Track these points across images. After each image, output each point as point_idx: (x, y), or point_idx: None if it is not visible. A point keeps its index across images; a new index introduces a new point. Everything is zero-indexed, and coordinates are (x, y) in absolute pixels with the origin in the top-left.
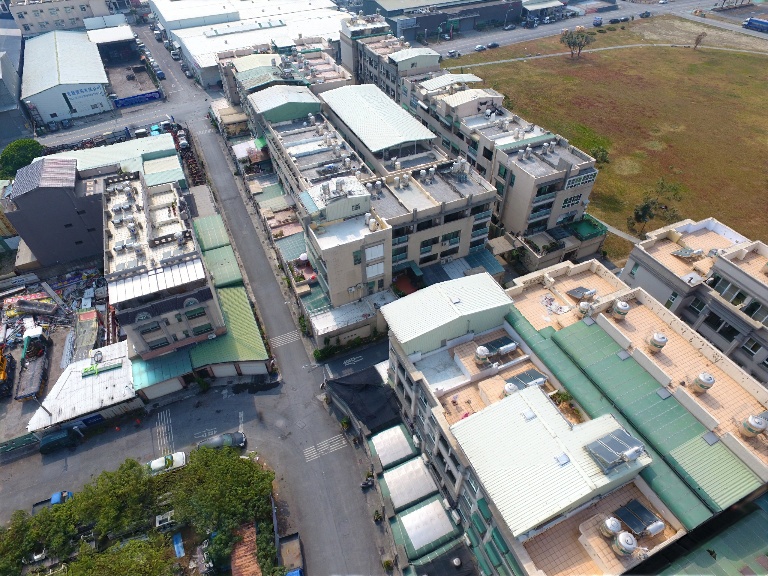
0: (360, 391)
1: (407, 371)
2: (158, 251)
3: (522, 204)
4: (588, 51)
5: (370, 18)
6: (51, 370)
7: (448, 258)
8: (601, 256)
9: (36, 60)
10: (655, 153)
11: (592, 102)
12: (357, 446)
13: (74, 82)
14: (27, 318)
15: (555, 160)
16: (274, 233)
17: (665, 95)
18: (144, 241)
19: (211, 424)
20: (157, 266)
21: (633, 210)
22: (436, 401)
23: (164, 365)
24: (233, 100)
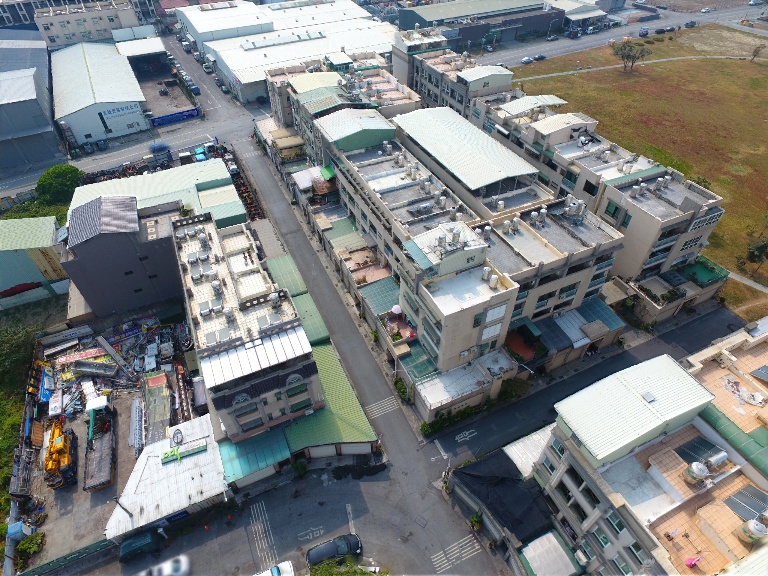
0: (495, 485)
1: (593, 487)
2: (251, 315)
3: (638, 248)
4: (640, 63)
5: (426, 32)
6: (119, 448)
7: (561, 311)
8: (718, 302)
9: (66, 75)
10: (742, 178)
11: (658, 120)
12: (494, 552)
13: (110, 100)
14: (85, 382)
15: (672, 197)
16: (354, 278)
17: (734, 112)
18: (231, 302)
19: (315, 521)
20: (254, 336)
21: (736, 246)
22: (654, 539)
23: (257, 449)
24: (285, 121)
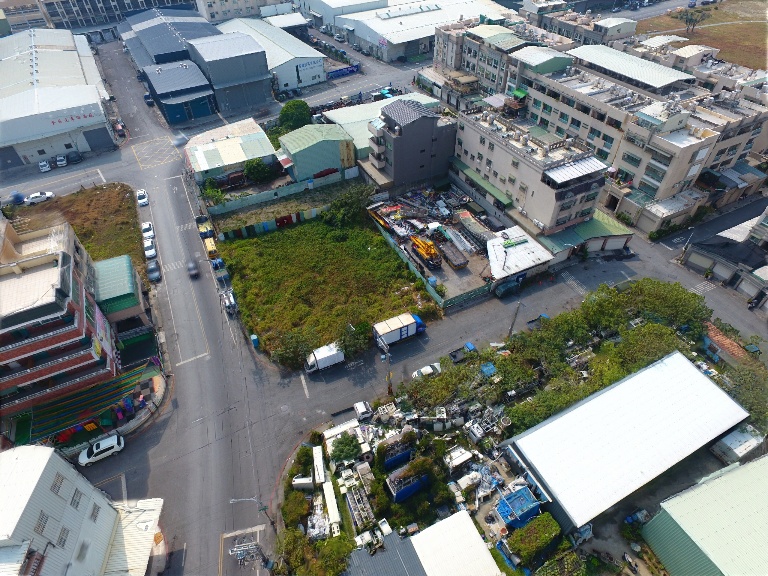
0: (722, 248)
1: None
2: (555, 153)
3: None
4: (697, 27)
5: None
6: None
7: (724, 167)
8: None
9: None
10: None
11: None
12: (725, 287)
13: (304, 56)
14: (410, 220)
15: None
16: None
17: None
18: None
19: (606, 278)
20: (569, 161)
21: None
22: None
23: (562, 238)
24: (455, 66)
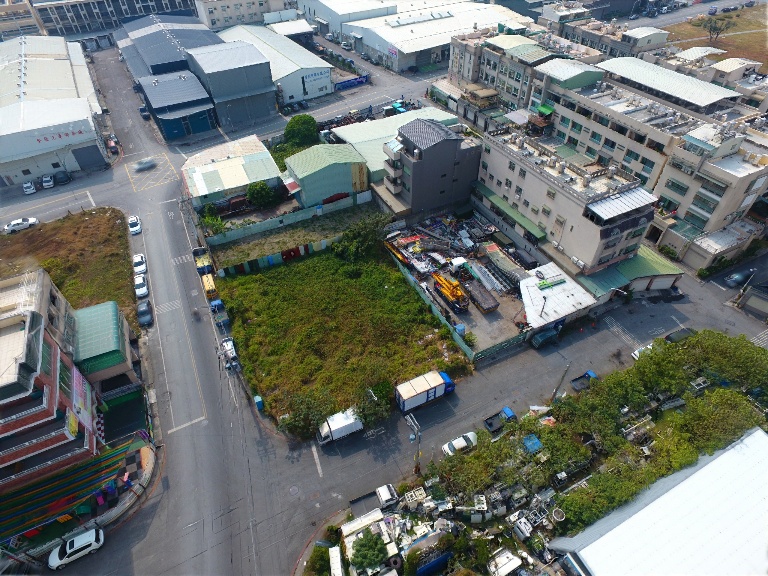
0: None
1: None
2: (597, 183)
3: None
4: (721, 36)
5: (571, 4)
6: None
7: None
8: None
9: None
10: None
11: None
12: None
13: (310, 66)
14: (431, 253)
15: None
16: None
17: None
18: None
19: (655, 325)
20: (614, 192)
21: None
22: None
23: (605, 279)
24: (472, 78)
